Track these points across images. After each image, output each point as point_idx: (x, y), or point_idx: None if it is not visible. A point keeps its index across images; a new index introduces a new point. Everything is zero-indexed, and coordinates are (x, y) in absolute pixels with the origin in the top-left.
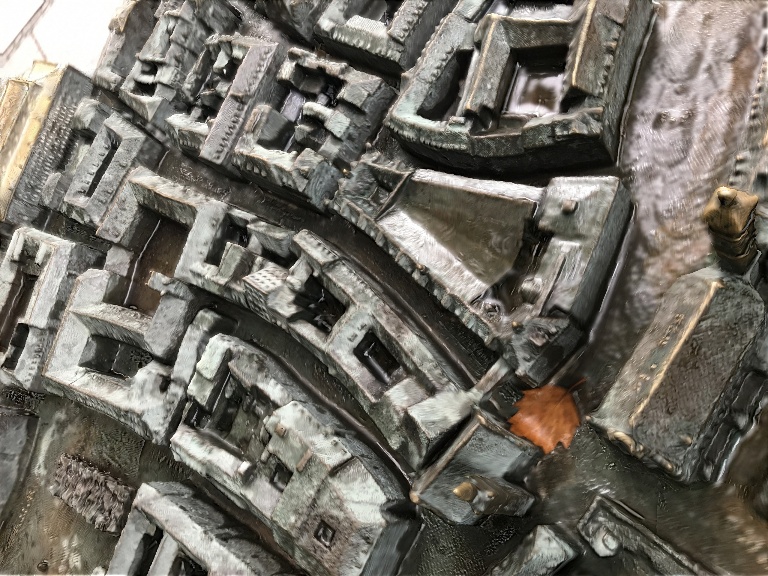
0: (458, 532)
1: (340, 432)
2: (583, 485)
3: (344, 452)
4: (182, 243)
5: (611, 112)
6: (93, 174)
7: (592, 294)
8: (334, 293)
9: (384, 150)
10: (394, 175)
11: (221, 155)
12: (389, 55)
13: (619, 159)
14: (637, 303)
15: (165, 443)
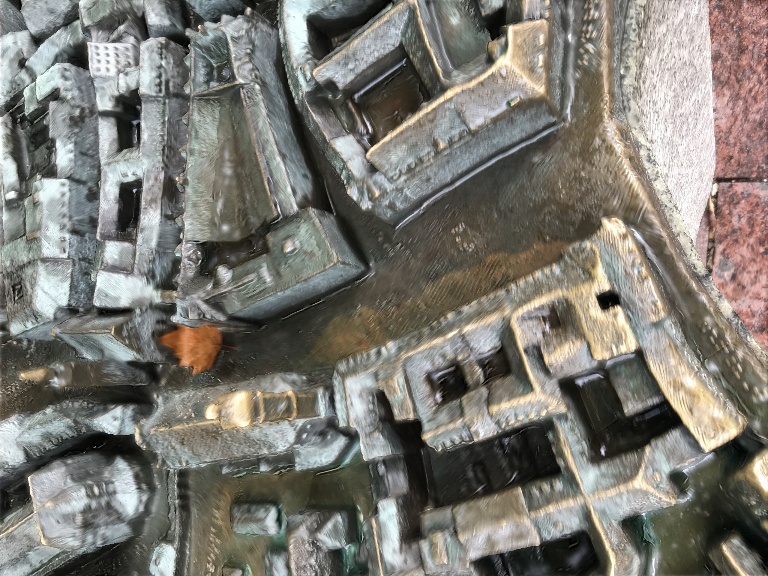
0: None
1: (81, 230)
2: None
3: (63, 251)
4: None
5: (408, 192)
6: None
7: (276, 308)
8: None
9: None
10: (232, 70)
11: None
12: None
13: (399, 226)
14: (303, 339)
15: (4, 109)
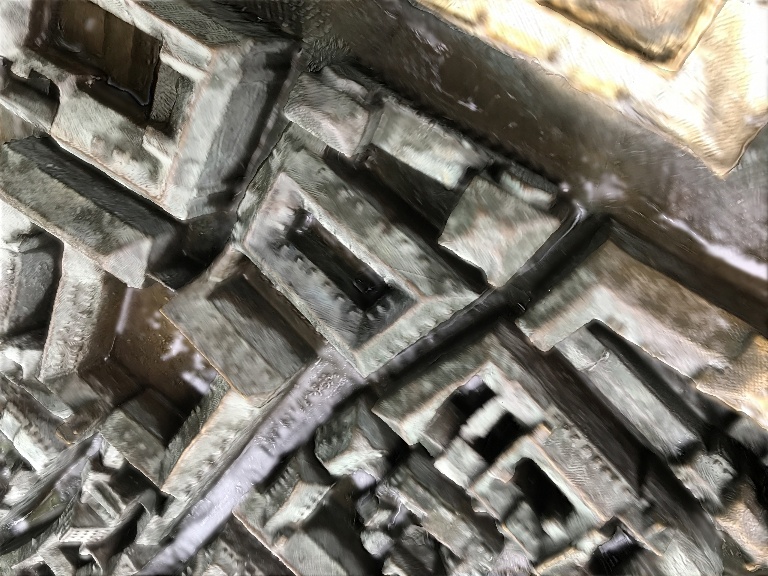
0: (0, 532)
1: None
2: None
3: None
4: (211, 366)
5: None
6: None
7: None
8: (84, 569)
9: None
10: None
11: None
12: None
13: None
14: None
15: None
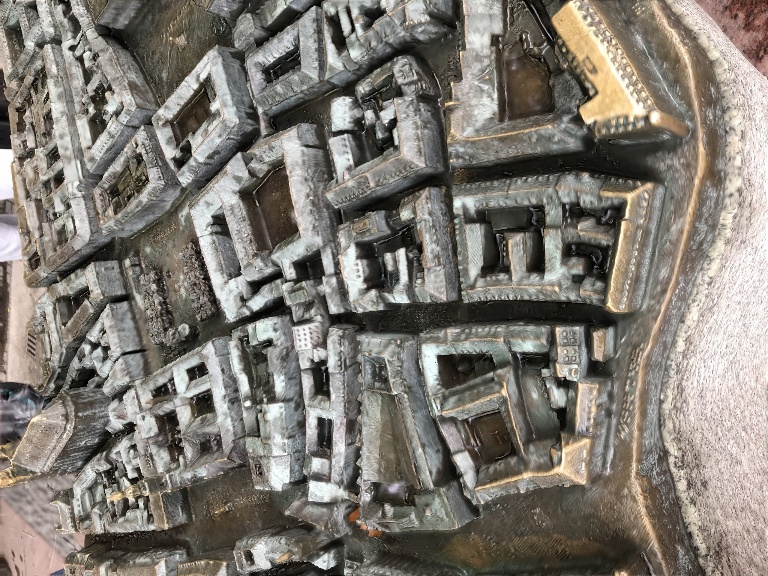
0: None
1: (293, 435)
2: (362, 550)
3: (285, 452)
4: None
5: None
6: (275, 57)
7: None
8: None
9: (428, 317)
10: (389, 383)
11: (339, 204)
12: (463, 294)
13: None
14: (437, 541)
15: None
